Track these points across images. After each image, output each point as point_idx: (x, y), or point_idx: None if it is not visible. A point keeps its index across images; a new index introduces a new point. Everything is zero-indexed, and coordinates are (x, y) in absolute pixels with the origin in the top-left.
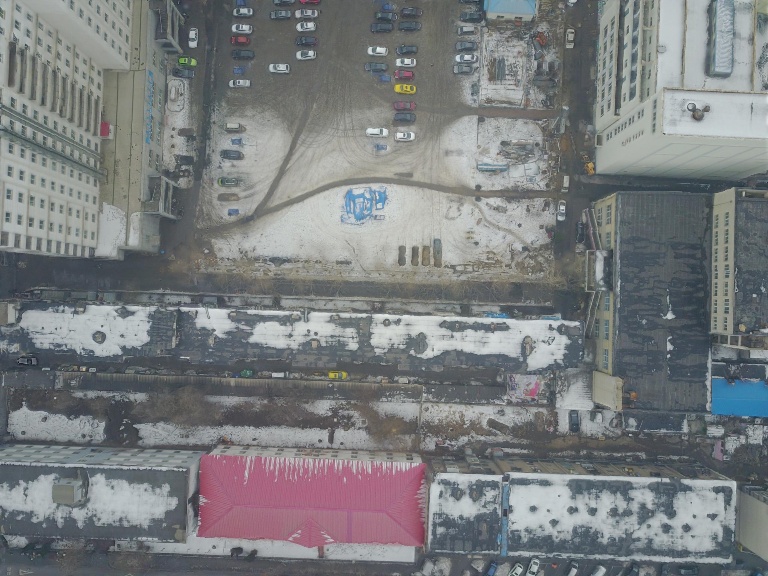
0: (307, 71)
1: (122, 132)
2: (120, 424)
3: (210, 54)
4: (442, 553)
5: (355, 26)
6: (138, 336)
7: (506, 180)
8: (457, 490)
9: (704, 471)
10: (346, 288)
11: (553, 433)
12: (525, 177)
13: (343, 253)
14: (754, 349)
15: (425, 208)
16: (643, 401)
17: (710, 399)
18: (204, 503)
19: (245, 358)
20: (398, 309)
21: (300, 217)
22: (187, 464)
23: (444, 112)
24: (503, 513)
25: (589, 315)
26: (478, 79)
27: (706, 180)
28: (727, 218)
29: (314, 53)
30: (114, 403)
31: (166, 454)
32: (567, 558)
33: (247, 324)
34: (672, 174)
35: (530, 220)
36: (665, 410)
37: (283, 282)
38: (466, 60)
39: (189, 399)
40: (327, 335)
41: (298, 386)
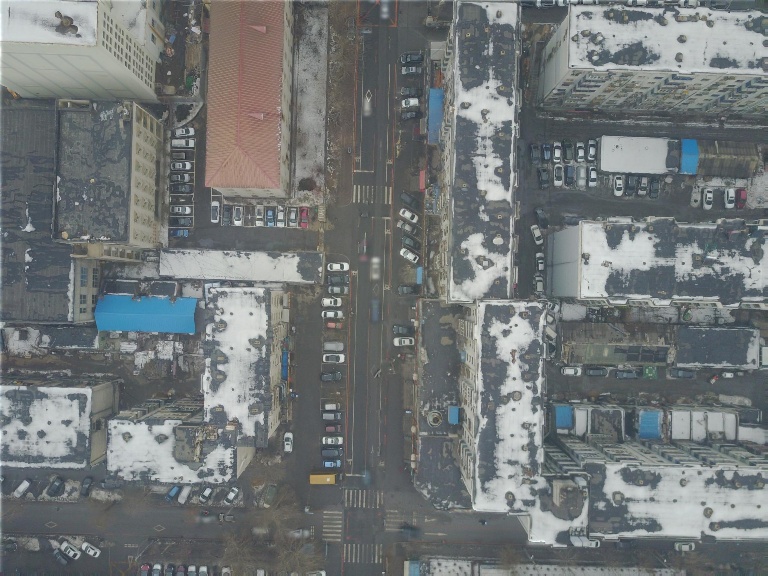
0: None
1: None
2: None
3: None
4: None
5: None
6: None
7: None
8: None
9: (92, 383)
10: None
11: None
12: None
13: None
14: (77, 256)
15: None
16: (3, 312)
17: (72, 310)
18: None
19: None
20: None
21: None
22: None
23: None
24: None
25: None
26: None
27: None
28: None
29: None
30: None
31: None
32: None
33: None
34: (85, 96)
35: None
36: (20, 320)
37: None
38: None
39: None
40: None
41: None
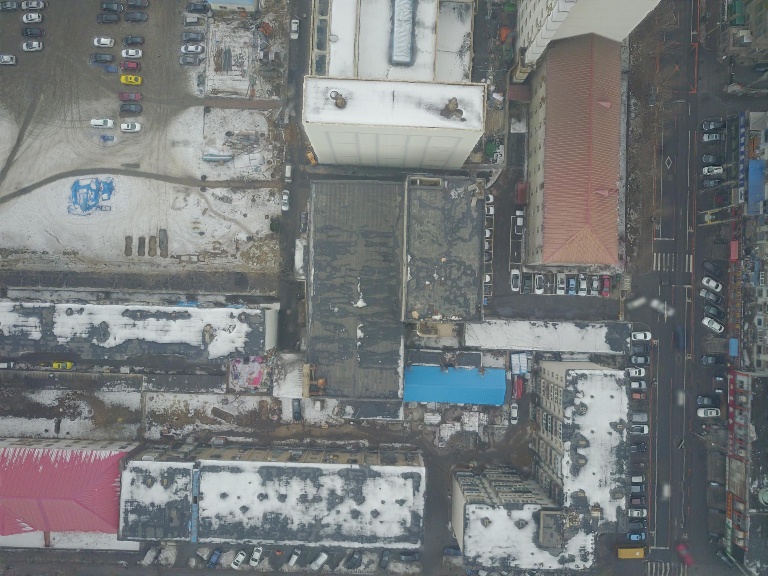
0: (34, 62)
1: None
2: None
3: None
4: (134, 540)
5: (82, 17)
6: None
7: (231, 170)
8: (148, 478)
9: (409, 458)
10: (73, 279)
11: (277, 421)
12: (250, 167)
13: (70, 244)
14: (427, 336)
15: (152, 199)
16: (334, 388)
17: (402, 386)
18: None
19: None
20: (123, 299)
21: (27, 208)
22: None
23: (171, 103)
24: (193, 500)
25: (306, 304)
26: (204, 70)
27: (428, 169)
28: None
29: (39, 44)
30: None
31: None
32: (257, 544)
33: None
34: (389, 163)
35: (256, 210)
36: (353, 397)
37: (10, 273)
38: (190, 51)
39: None
40: (10, 325)
41: (19, 376)
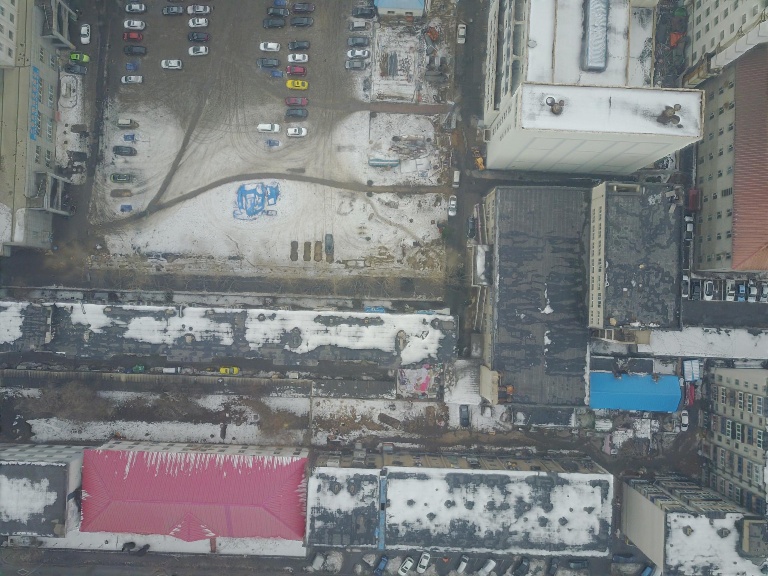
0: (200, 67)
1: (7, 128)
2: (13, 420)
3: (103, 50)
4: (320, 547)
5: (248, 22)
6: (10, 331)
7: (397, 175)
8: (335, 484)
9: (587, 465)
10: (238, 284)
11: (444, 428)
12: (417, 172)
13: (235, 249)
14: (625, 343)
15: (317, 203)
16: (521, 395)
17: (588, 393)
18: (86, 498)
19: (137, 354)
20: (290, 304)
21: (193, 213)
22: (70, 459)
23: (336, 108)
24: (380, 507)
25: (477, 310)
26: (370, 74)
27: (596, 175)
28: (600, 212)
29: (206, 49)
30: (7, 399)
31: (55, 449)
32: (445, 551)
33: (122, 319)
34: (560, 169)
35: (422, 215)
36: (542, 404)
37: (176, 278)
38: (357, 55)
39: (72, 394)
40: (202, 330)
41: (188, 381)
